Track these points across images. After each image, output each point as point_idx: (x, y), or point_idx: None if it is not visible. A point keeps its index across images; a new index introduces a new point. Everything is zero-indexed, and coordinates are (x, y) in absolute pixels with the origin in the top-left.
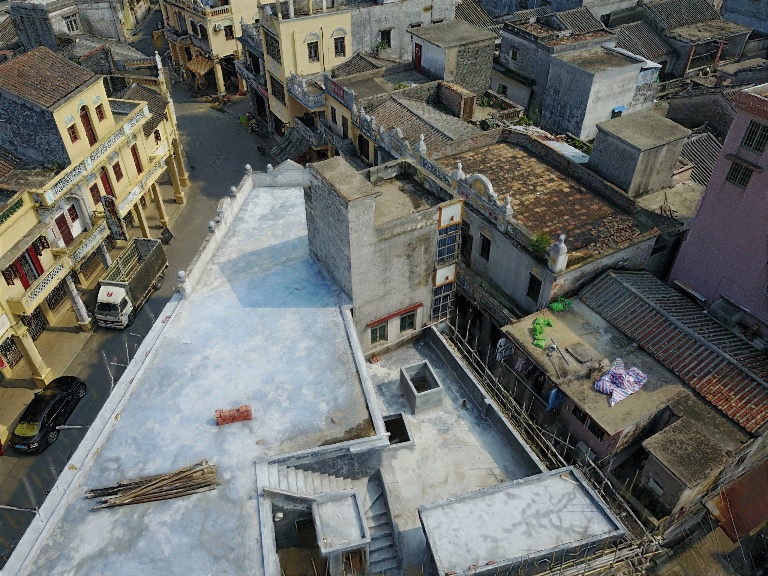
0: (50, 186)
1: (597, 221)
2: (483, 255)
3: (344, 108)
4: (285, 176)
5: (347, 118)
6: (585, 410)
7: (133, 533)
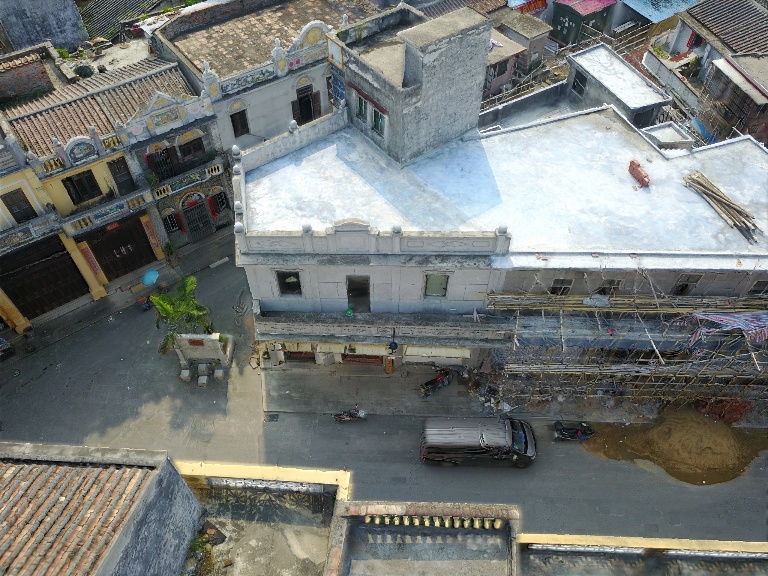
0: (323, 473)
1: (333, 4)
2: (330, 98)
3: (2, 181)
4: (243, 201)
5: (18, 188)
6: (510, 56)
7: (760, 207)
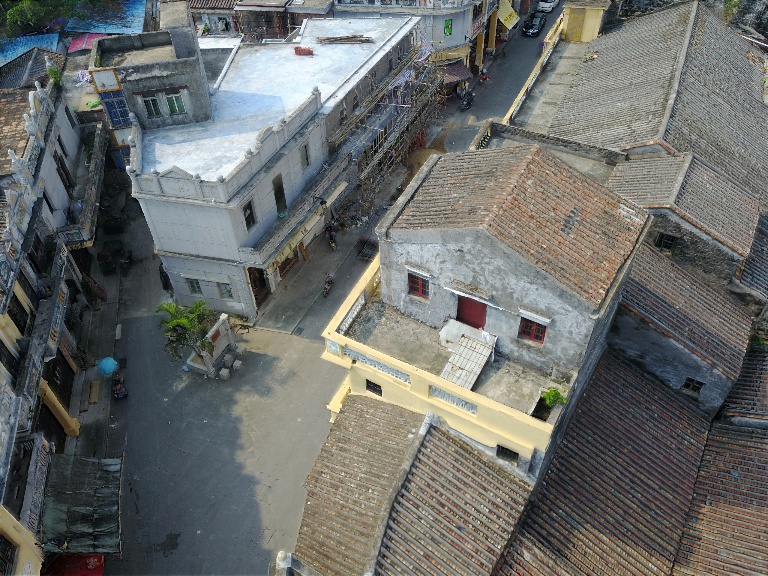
0: None
1: None
2: None
3: None
4: None
5: None
6: None
7: None
